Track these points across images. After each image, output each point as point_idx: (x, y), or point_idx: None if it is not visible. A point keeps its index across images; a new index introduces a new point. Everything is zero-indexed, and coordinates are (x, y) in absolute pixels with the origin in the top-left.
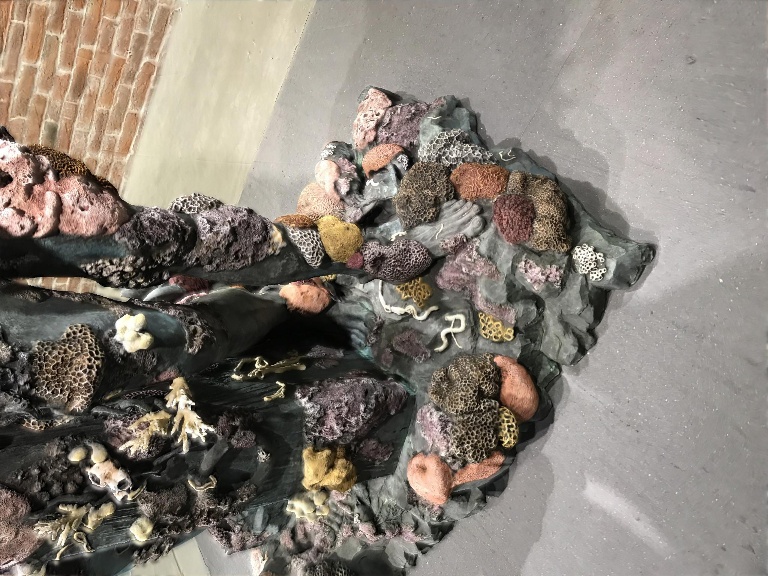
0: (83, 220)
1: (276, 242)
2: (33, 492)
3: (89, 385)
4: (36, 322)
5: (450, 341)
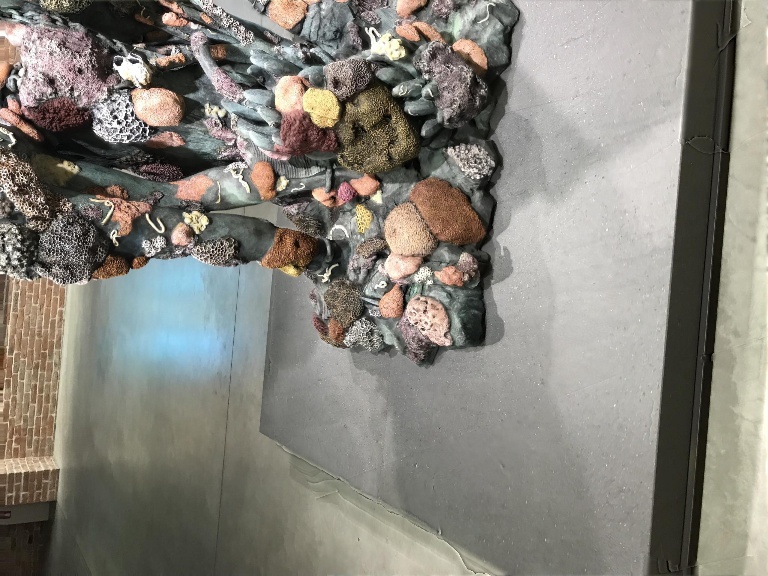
0: None
1: None
2: None
3: None
4: None
5: None
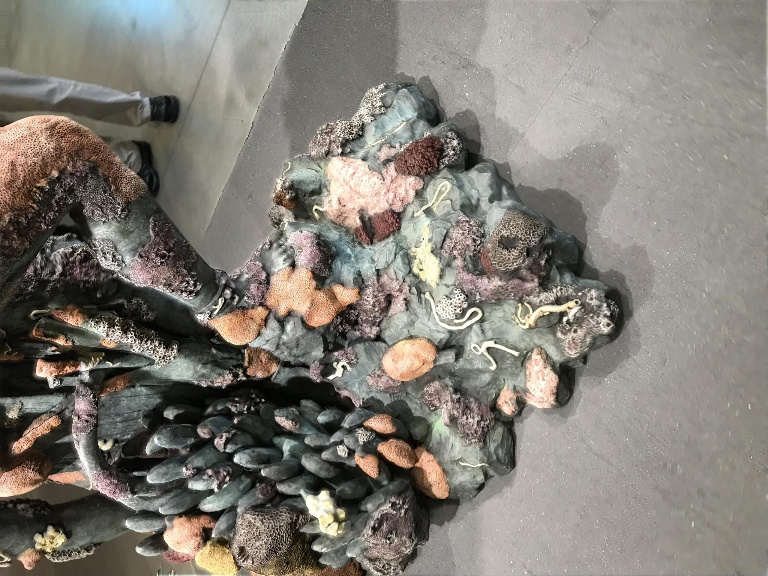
0: None
1: None
2: None
3: None
4: None
5: None
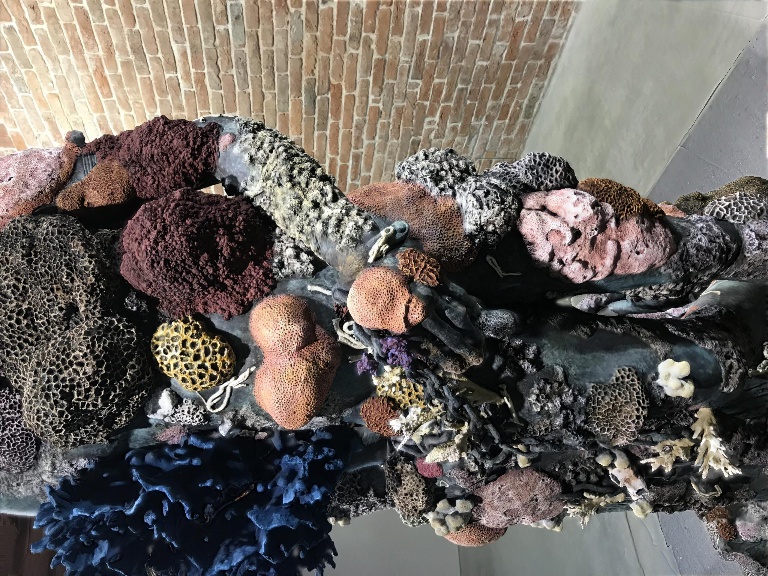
0: (637, 263)
1: None
2: (564, 478)
3: (635, 432)
4: (589, 362)
5: None
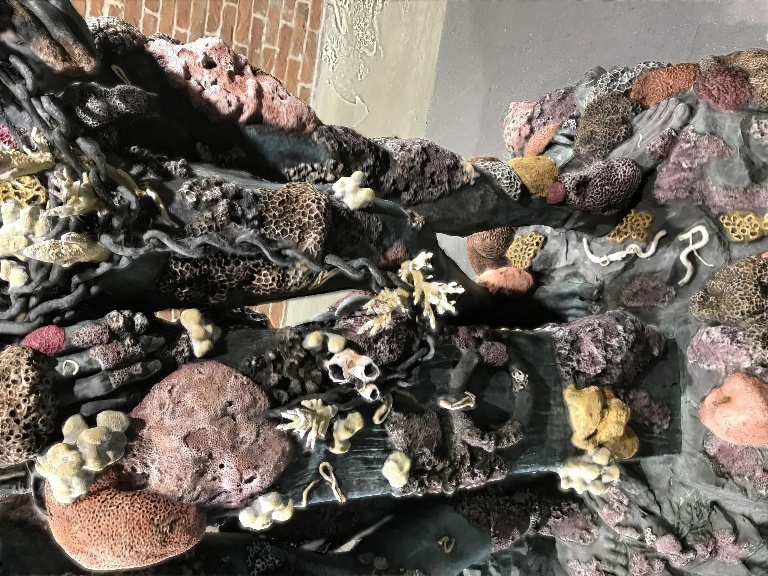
0: (283, 108)
1: (468, 172)
2: (269, 388)
3: (320, 217)
4: (253, 182)
5: (695, 263)
